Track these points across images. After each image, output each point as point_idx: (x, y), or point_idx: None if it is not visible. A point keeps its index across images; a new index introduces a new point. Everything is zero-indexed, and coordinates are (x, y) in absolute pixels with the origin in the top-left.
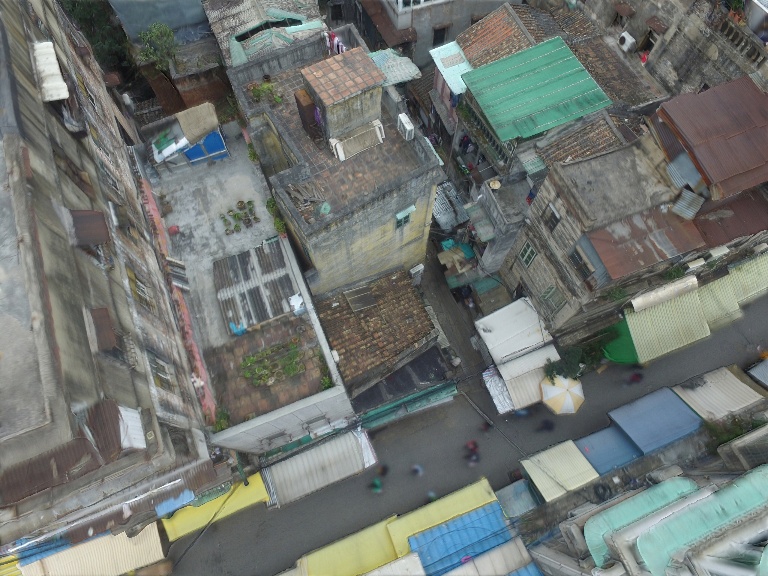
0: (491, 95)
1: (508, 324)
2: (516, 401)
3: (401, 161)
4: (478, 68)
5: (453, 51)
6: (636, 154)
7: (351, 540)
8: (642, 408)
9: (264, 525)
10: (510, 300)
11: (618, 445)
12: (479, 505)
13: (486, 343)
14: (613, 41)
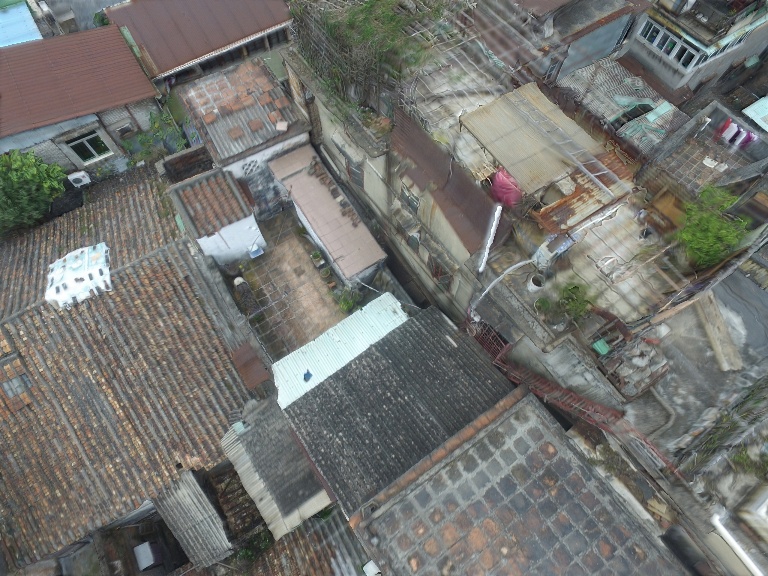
0: None
1: None
2: None
3: None
4: None
5: None
6: None
7: None
8: None
9: None
10: None
11: None
12: None
13: None
14: None
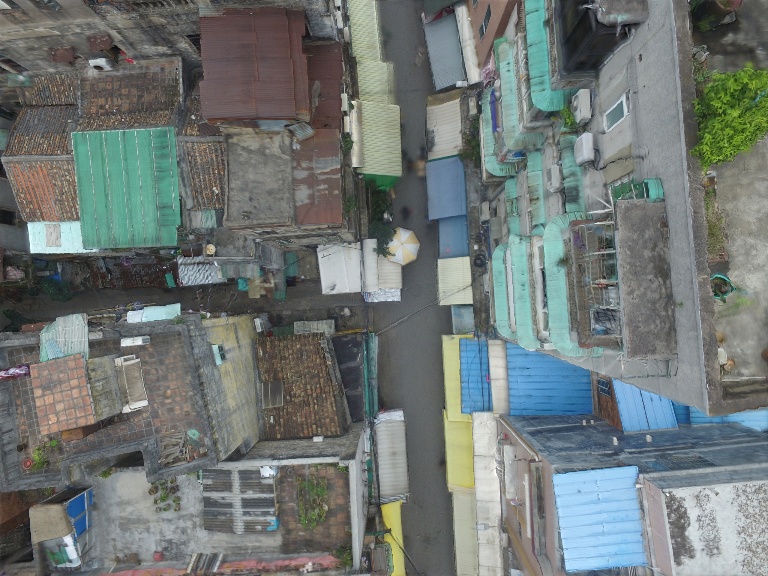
0: (119, 232)
1: (334, 270)
2: (396, 285)
3: (166, 349)
4: (81, 229)
5: (41, 230)
6: (237, 143)
7: (449, 448)
8: (434, 193)
9: (416, 500)
10: (313, 252)
11: (454, 226)
12: (458, 350)
13: (343, 292)
14: (92, 70)
